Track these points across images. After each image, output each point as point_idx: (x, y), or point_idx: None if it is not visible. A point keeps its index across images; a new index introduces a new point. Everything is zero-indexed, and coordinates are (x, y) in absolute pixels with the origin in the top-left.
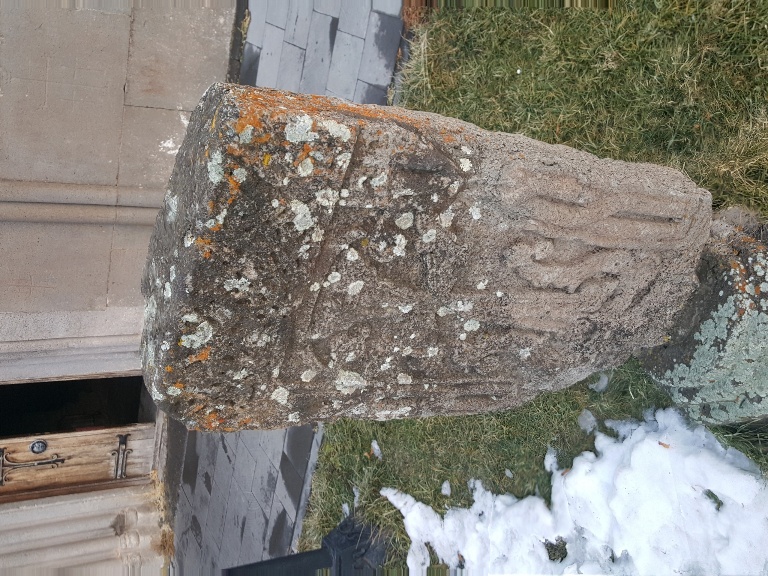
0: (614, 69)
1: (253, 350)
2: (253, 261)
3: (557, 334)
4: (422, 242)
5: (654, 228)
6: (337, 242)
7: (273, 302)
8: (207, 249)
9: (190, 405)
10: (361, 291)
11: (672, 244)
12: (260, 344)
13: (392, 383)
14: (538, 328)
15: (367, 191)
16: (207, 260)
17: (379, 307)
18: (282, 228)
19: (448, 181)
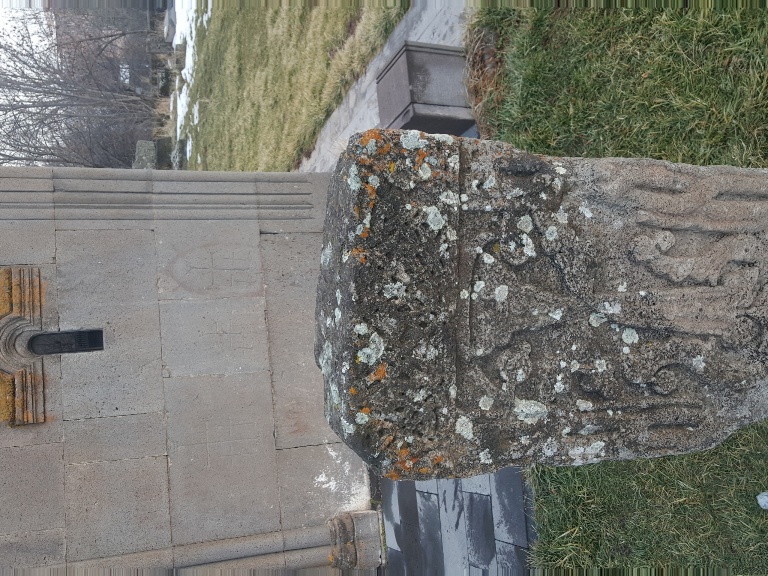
0: None
1: (425, 365)
2: (403, 264)
3: (723, 338)
4: (547, 241)
5: (764, 206)
6: (471, 246)
7: (430, 307)
8: (362, 256)
9: (380, 437)
10: (508, 298)
11: None
12: (430, 357)
13: (573, 411)
14: (699, 331)
15: (482, 194)
16: (364, 266)
17: (530, 316)
18: (420, 229)
19: (549, 178)
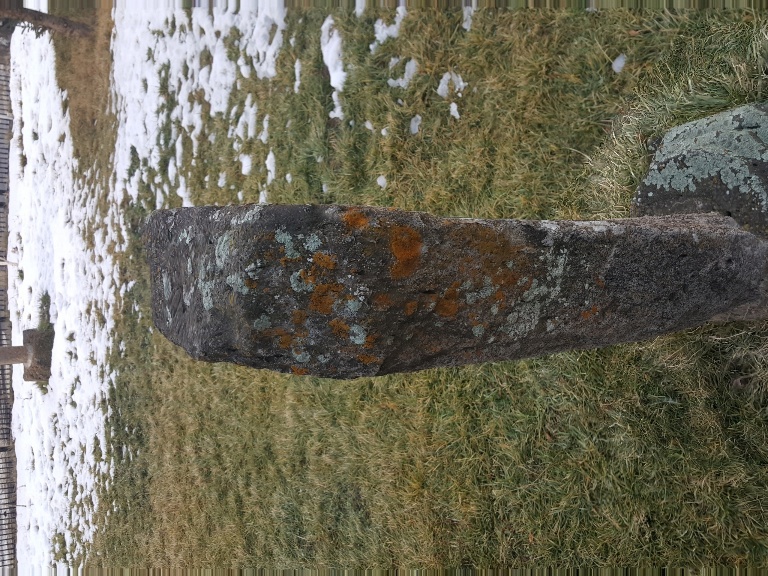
0: (645, 513)
1: None
2: None
3: None
4: None
5: None
6: None
7: None
8: None
9: None
10: None
11: None
12: None
13: None
14: None
15: None
16: None
17: None
18: None
19: None
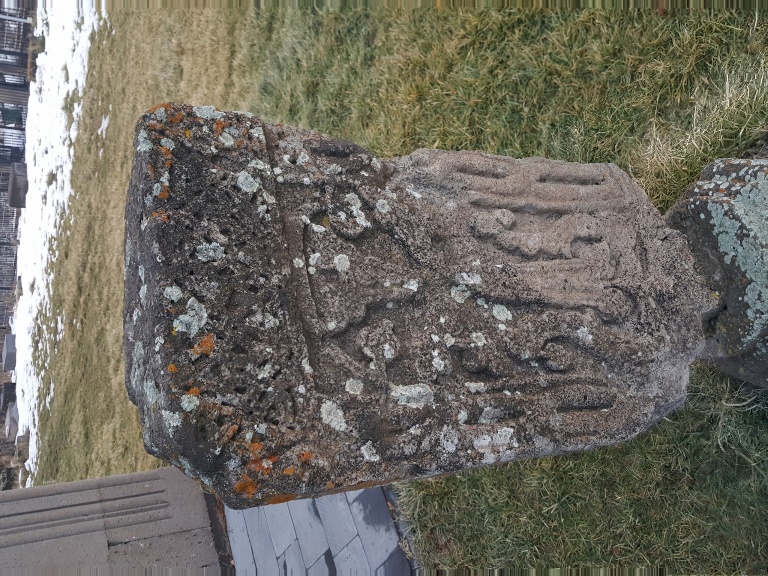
0: None
1: (264, 335)
2: (216, 224)
3: (599, 309)
4: (380, 213)
5: (588, 188)
6: (295, 216)
7: (258, 269)
8: (164, 216)
9: (220, 427)
10: (351, 268)
11: (619, 201)
12: (269, 325)
13: (464, 394)
14: (572, 302)
15: (297, 168)
16: (168, 224)
17: (382, 287)
18: (230, 191)
19: (366, 158)
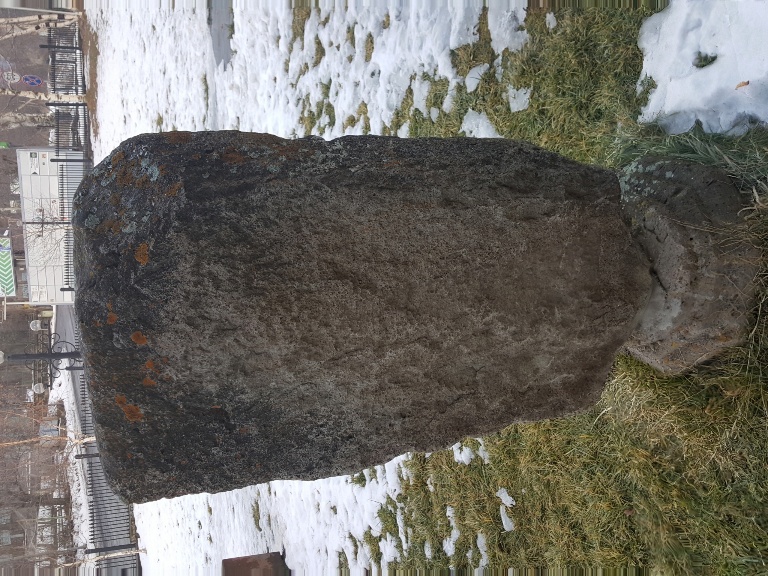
0: None
1: None
2: None
3: None
4: None
5: None
6: None
7: None
8: None
9: None
10: None
11: None
12: None
13: None
14: None
15: None
16: None
17: None
18: None
19: None
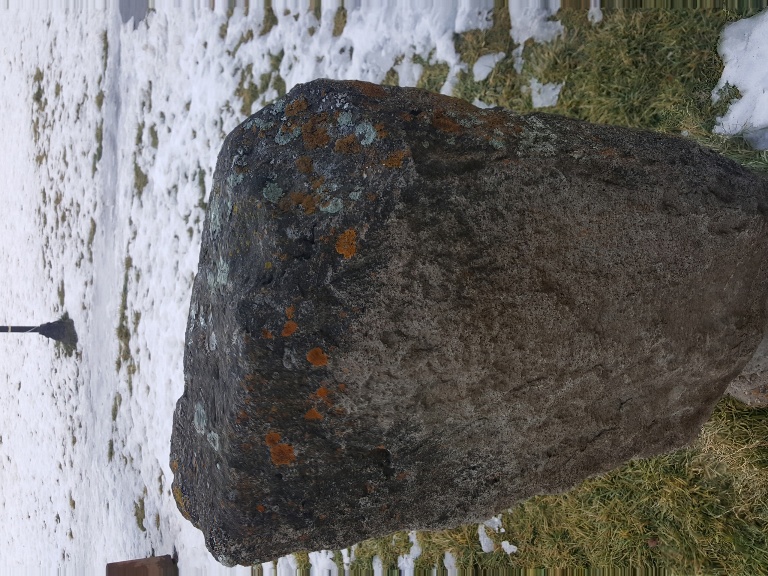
0: None
1: None
2: None
3: None
4: None
5: None
6: None
7: None
8: None
9: None
10: None
11: None
12: None
13: None
14: None
15: None
16: None
17: None
18: None
19: None
